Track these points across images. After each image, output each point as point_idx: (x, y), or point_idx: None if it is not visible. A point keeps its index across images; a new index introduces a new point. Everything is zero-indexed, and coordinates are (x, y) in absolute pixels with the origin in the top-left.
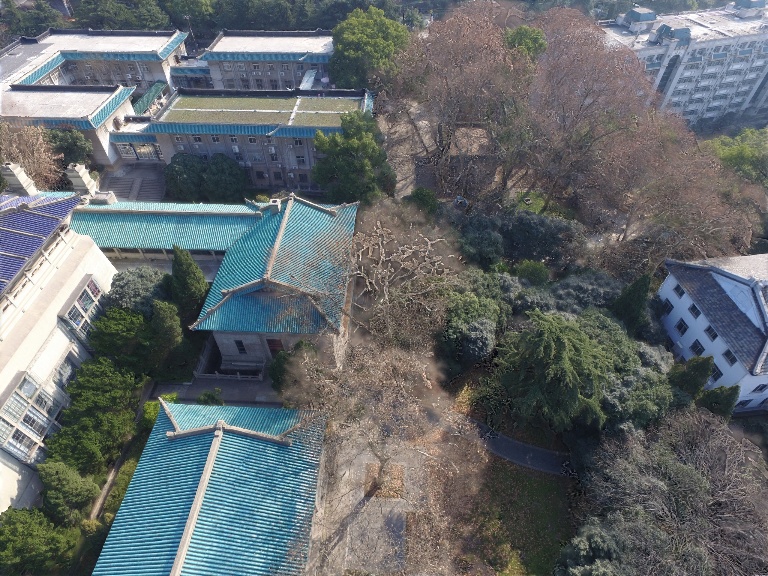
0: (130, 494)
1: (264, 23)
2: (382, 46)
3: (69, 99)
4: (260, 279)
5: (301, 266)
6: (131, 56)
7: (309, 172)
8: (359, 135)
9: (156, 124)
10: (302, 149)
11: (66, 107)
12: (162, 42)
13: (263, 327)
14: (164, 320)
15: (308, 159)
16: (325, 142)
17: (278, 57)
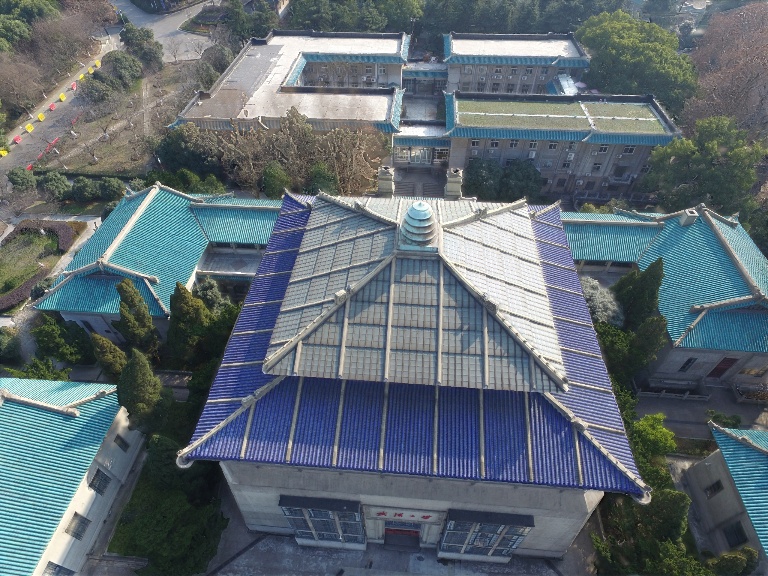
0: (766, 528)
1: (484, 26)
2: (660, 51)
3: (348, 101)
4: (752, 295)
5: (760, 282)
6: (373, 58)
7: (600, 179)
8: (734, 143)
9: (460, 128)
10: (605, 156)
11: (352, 109)
12: (393, 44)
13: (750, 346)
14: (660, 337)
15: (605, 166)
16: (689, 150)
17: (527, 61)
